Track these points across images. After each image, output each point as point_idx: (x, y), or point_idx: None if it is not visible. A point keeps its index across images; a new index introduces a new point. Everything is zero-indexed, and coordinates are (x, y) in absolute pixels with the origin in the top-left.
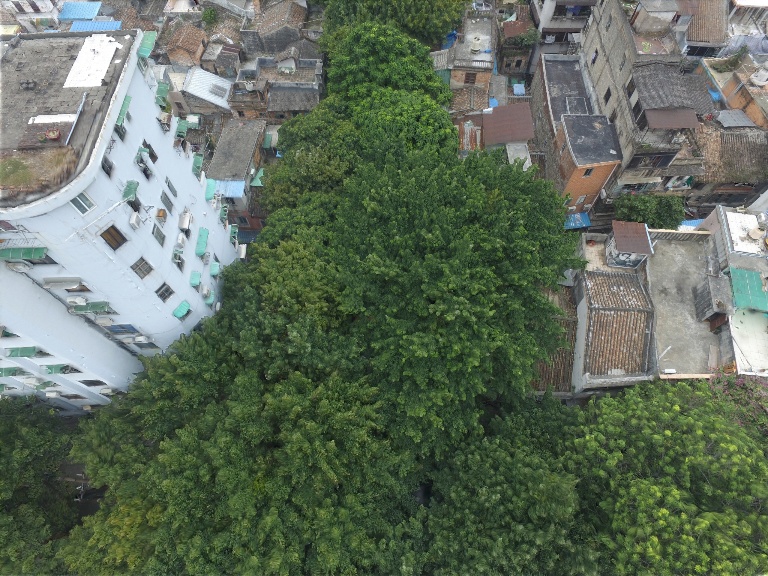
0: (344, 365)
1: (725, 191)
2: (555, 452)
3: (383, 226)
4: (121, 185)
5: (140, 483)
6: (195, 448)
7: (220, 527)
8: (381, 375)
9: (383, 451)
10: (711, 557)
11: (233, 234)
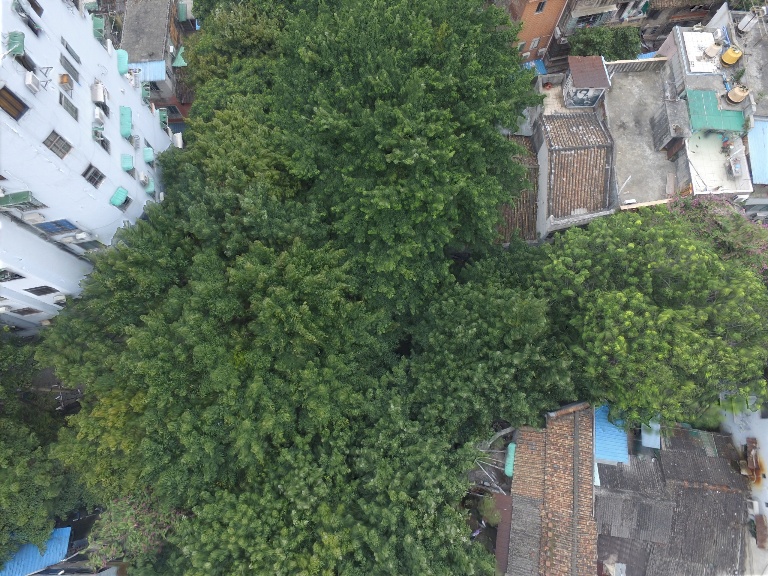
0: (306, 230)
1: (681, 18)
2: (525, 290)
3: (326, 81)
4: (1, 36)
5: (116, 375)
6: (165, 332)
7: (208, 403)
8: (346, 240)
9: (358, 312)
10: (673, 345)
11: (163, 119)
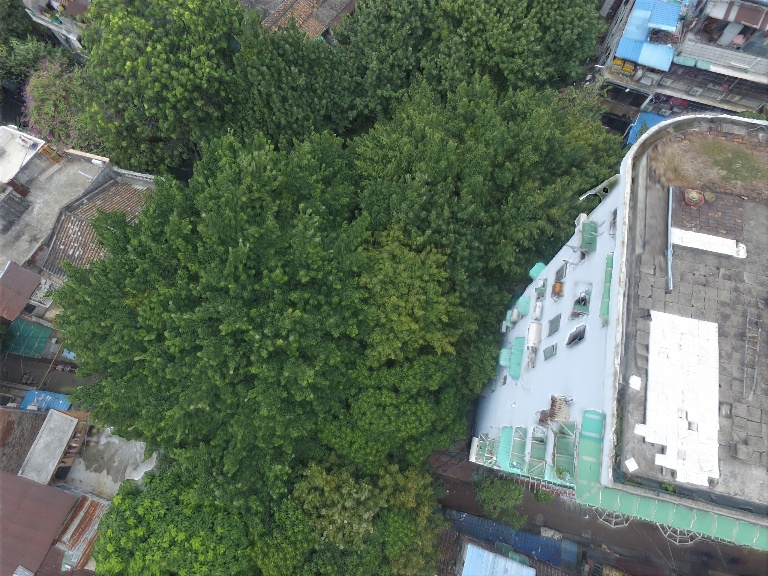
0: None
1: None
2: None
3: None
4: None
5: (569, 156)
6: None
7: None
8: None
9: None
10: None
11: (483, 445)
